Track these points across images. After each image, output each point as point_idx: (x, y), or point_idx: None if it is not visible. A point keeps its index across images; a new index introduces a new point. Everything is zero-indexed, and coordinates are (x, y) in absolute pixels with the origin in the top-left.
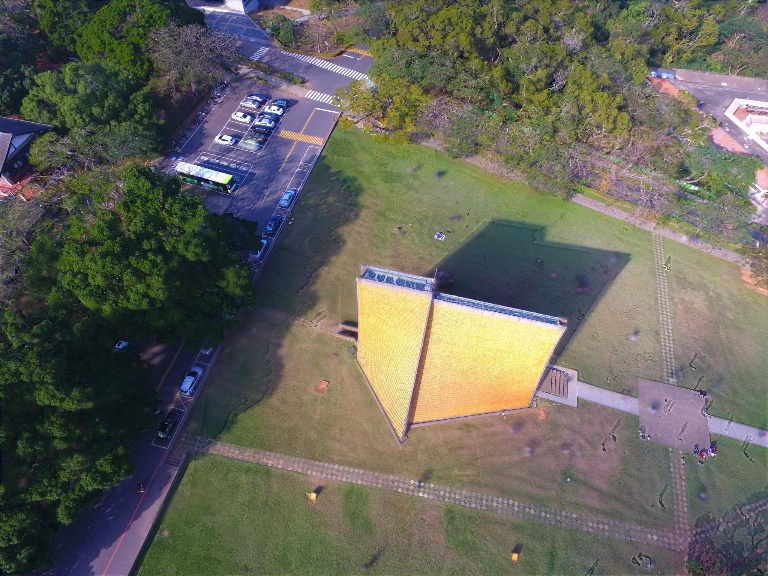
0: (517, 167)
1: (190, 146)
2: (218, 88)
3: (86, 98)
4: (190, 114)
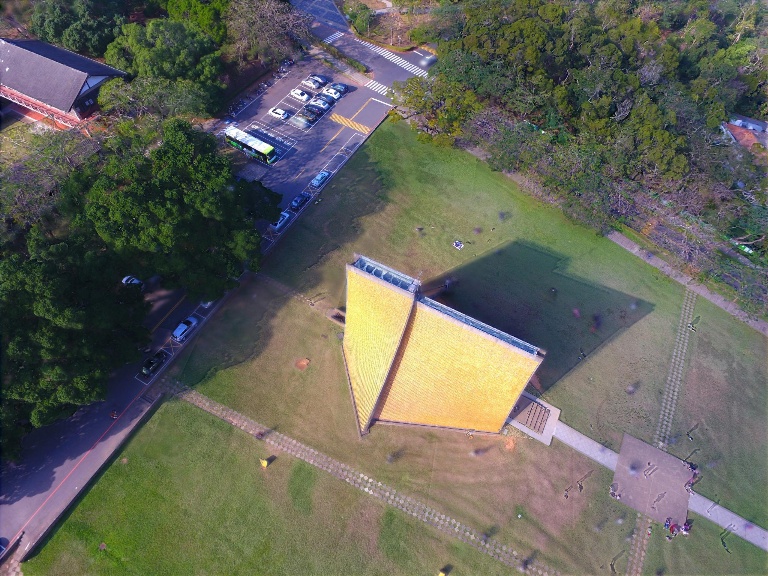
0: (555, 191)
1: (245, 113)
2: (285, 64)
3: (161, 53)
4: (253, 84)
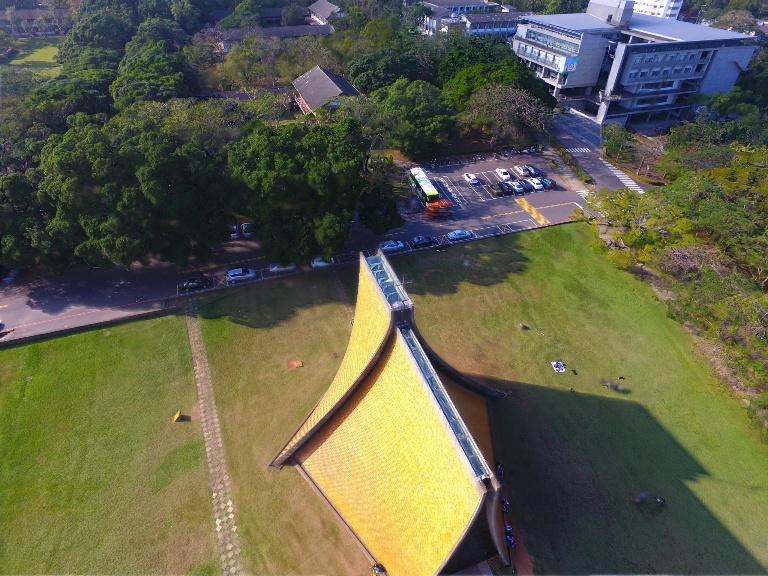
0: (748, 376)
1: (444, 169)
2: (512, 151)
3: (408, 101)
4: (471, 154)
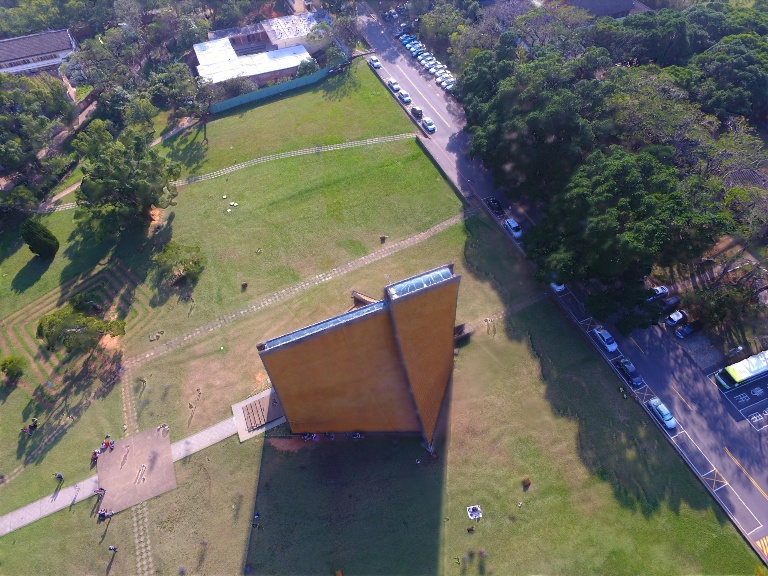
0: None
1: None
2: None
3: None
4: None
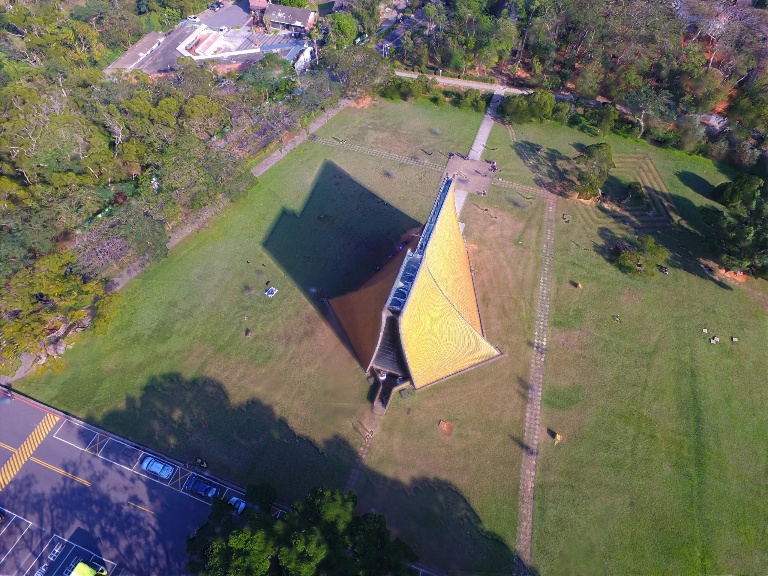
0: (212, 200)
1: None
2: None
3: None
4: None
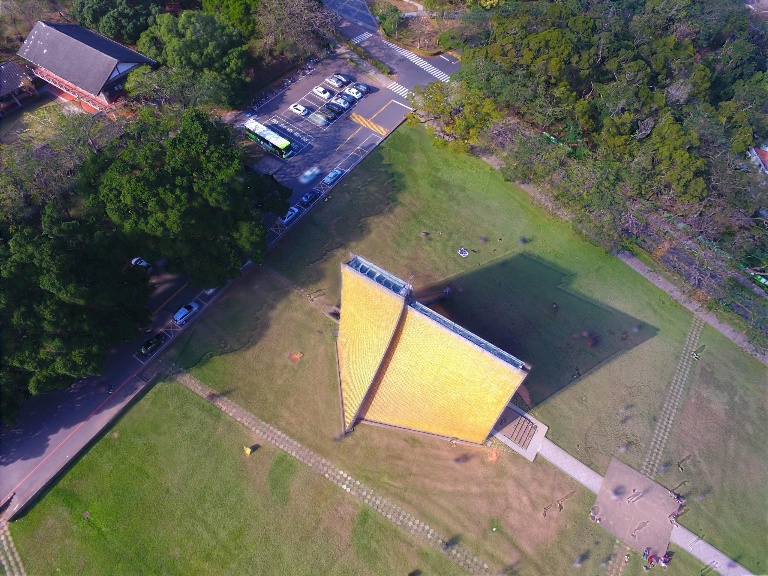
0: (566, 206)
1: (267, 107)
2: (311, 61)
3: (190, 43)
4: (278, 79)
